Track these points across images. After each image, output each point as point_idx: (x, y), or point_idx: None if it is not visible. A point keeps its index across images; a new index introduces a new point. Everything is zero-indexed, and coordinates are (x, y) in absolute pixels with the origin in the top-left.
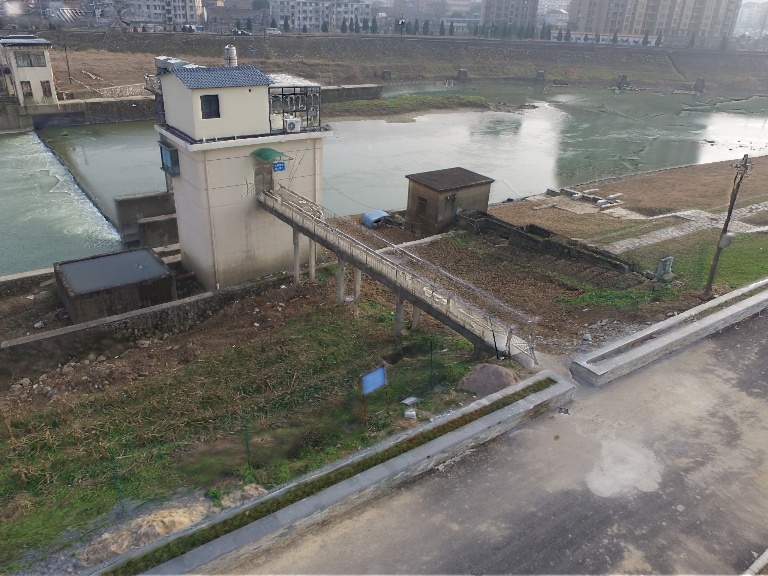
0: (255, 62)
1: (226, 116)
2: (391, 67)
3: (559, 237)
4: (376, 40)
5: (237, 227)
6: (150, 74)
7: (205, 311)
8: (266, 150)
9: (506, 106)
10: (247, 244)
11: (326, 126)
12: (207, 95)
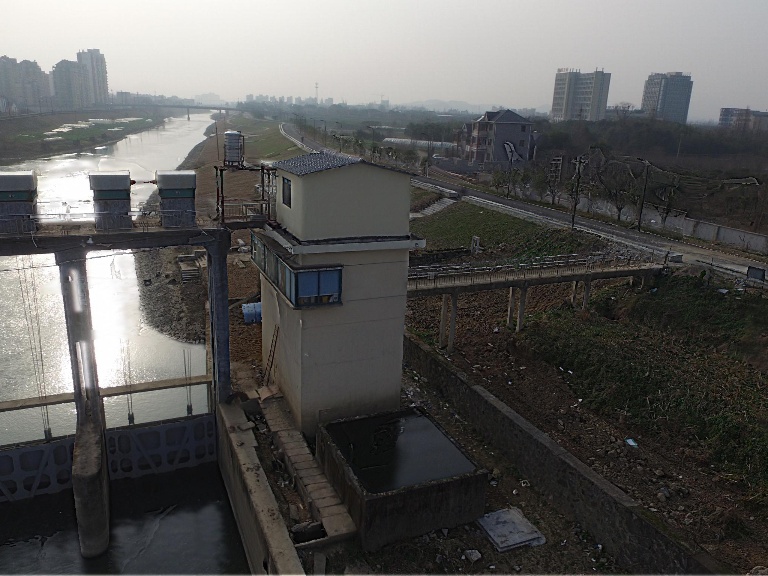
0: None
1: None
2: None
3: (419, 251)
4: None
5: None
6: None
7: None
8: None
9: None
10: None
11: None
12: None
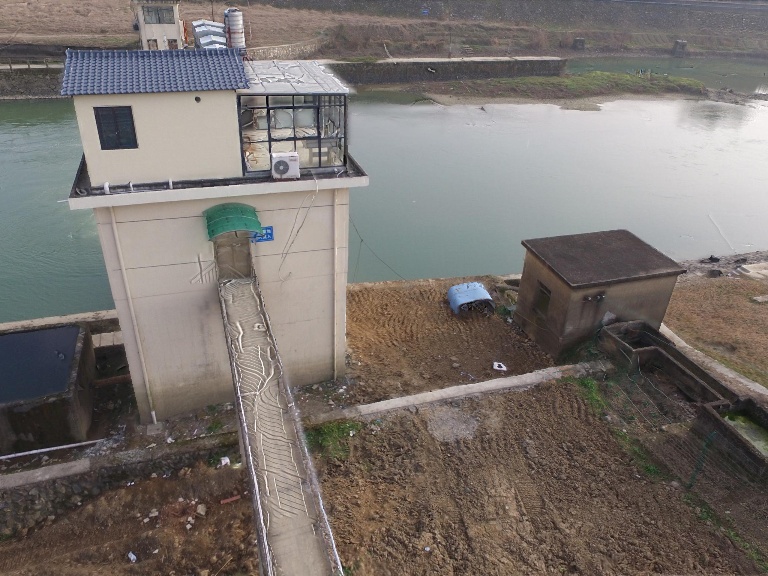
0: (424, 23)
1: (150, 145)
2: (587, 34)
3: None
4: (574, 0)
5: (184, 328)
6: (303, 34)
7: (69, 496)
8: (227, 210)
9: (733, 94)
10: (205, 354)
11: (480, 109)
12: (108, 106)
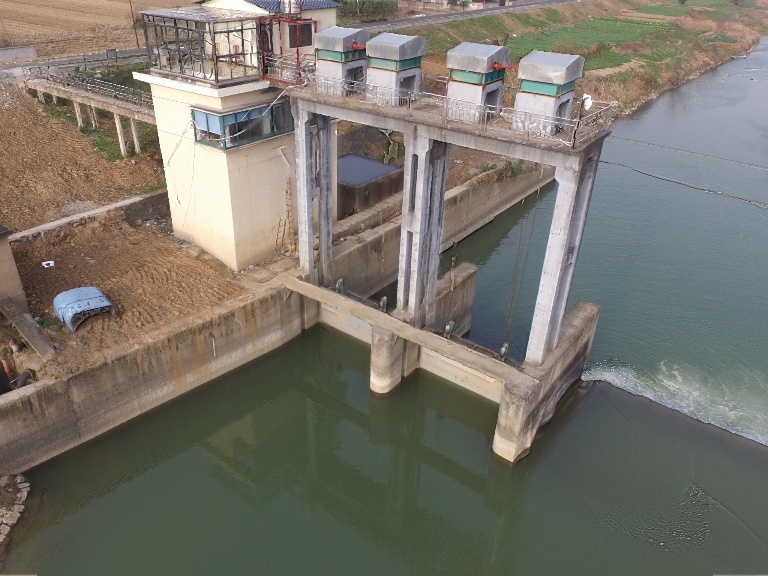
0: None
1: None
2: None
3: None
4: None
5: None
6: None
7: None
8: None
9: None
10: None
11: None
12: None
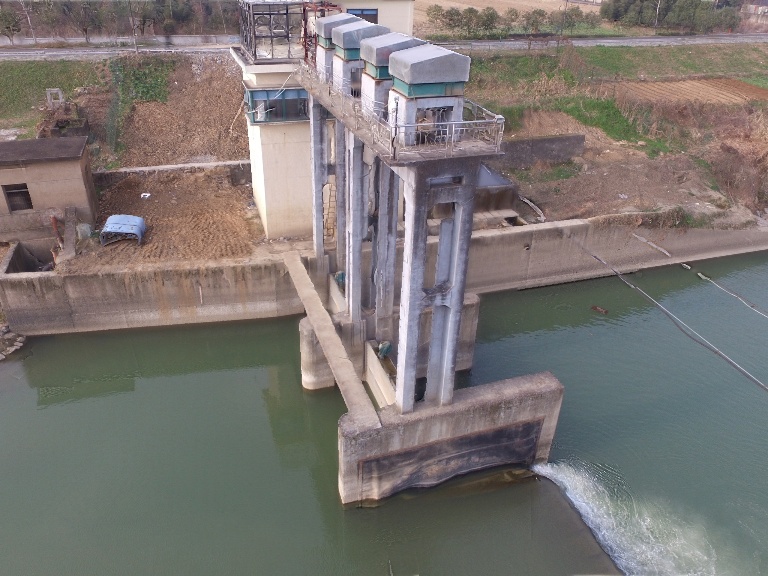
0: None
1: None
2: None
3: (65, 117)
4: None
5: None
6: None
7: None
8: None
9: None
10: None
11: None
12: None
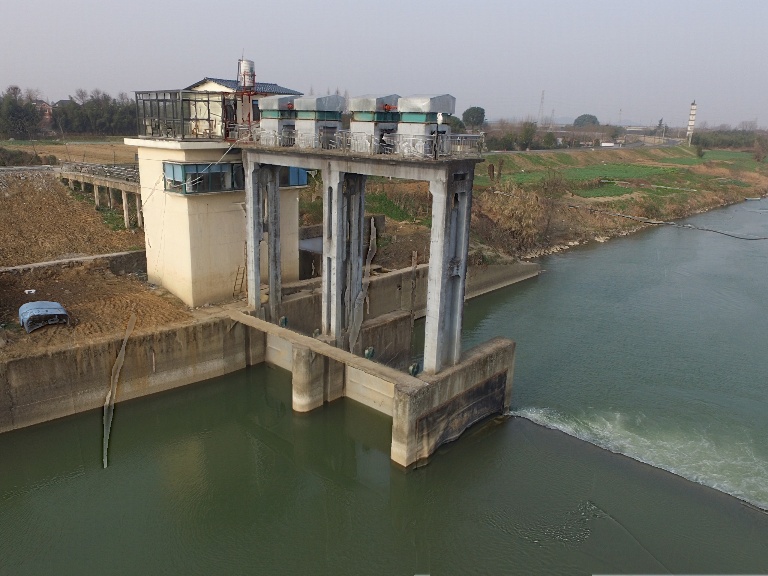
0: None
1: None
2: None
3: None
4: None
5: None
6: None
7: None
8: None
9: None
10: None
11: None
12: None
